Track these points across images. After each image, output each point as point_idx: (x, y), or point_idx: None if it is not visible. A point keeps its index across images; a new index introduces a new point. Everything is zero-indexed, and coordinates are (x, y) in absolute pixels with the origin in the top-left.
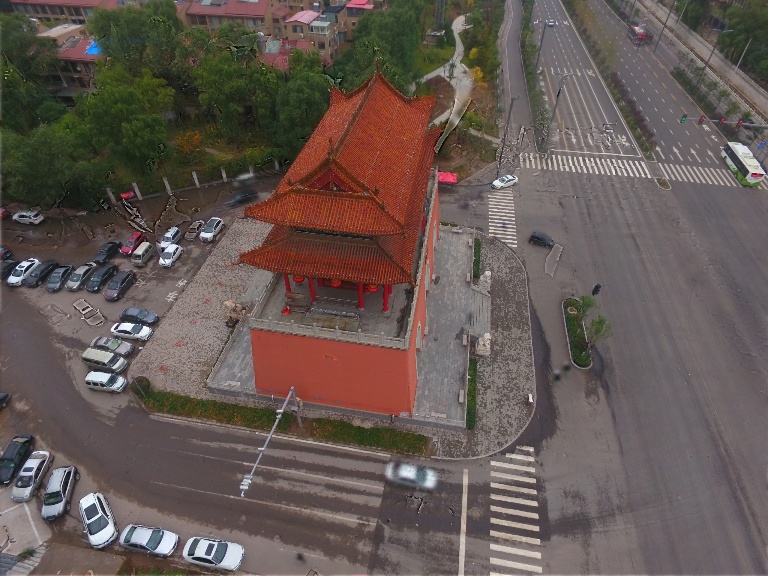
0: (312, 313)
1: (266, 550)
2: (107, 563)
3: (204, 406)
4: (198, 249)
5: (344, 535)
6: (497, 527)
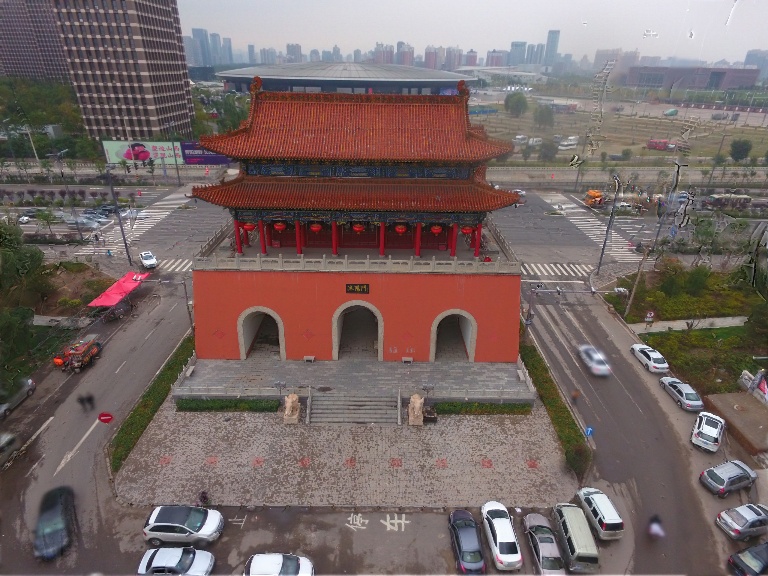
0: (487, 247)
1: (620, 341)
2: (720, 402)
3: (554, 400)
4: (247, 537)
5: (580, 315)
6: (528, 273)
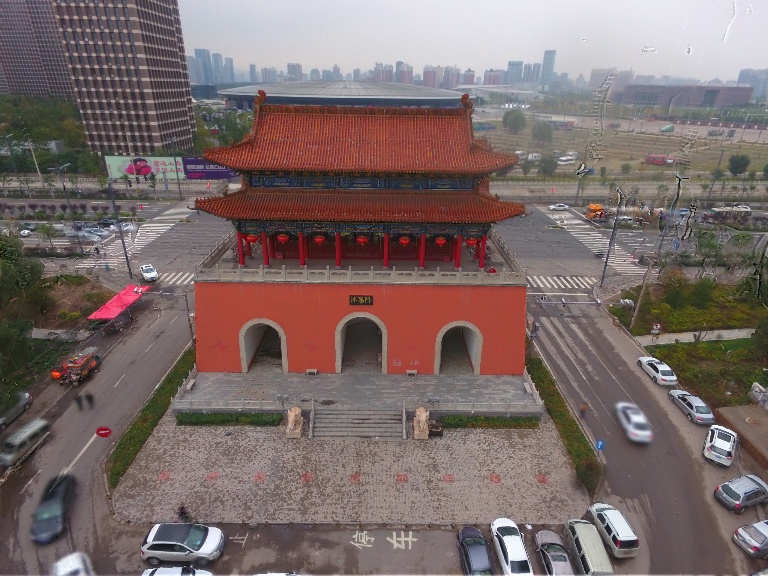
0: None
1: (627, 354)
2: (731, 415)
3: (562, 413)
4: (248, 556)
5: (585, 327)
6: (531, 285)
